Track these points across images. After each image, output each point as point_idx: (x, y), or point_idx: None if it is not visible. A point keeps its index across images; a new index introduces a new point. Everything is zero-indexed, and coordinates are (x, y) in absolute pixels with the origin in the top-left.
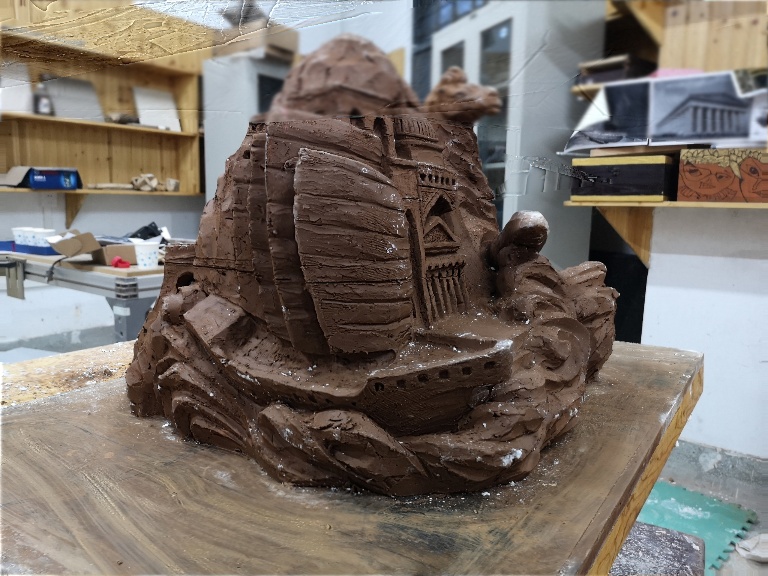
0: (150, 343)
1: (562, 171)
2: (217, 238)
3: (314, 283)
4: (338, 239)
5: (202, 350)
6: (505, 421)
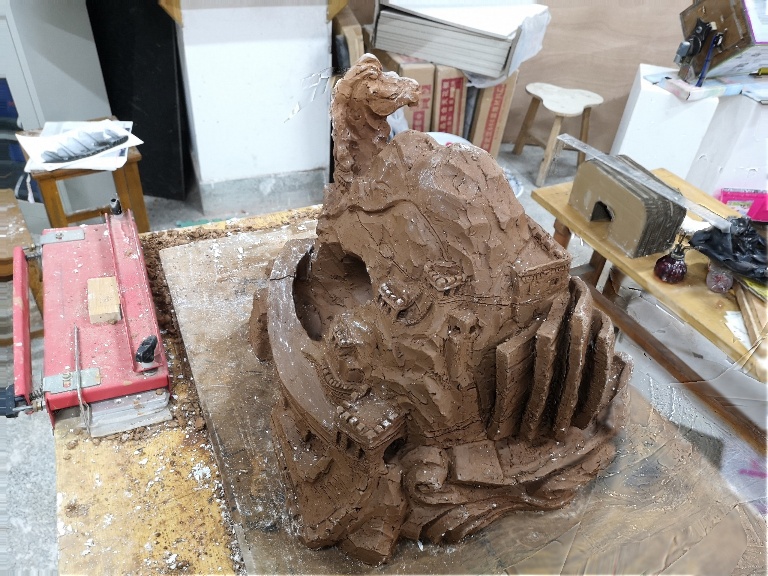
0: (398, 515)
1: (335, 72)
2: (459, 408)
3: None
4: None
5: (466, 486)
6: None
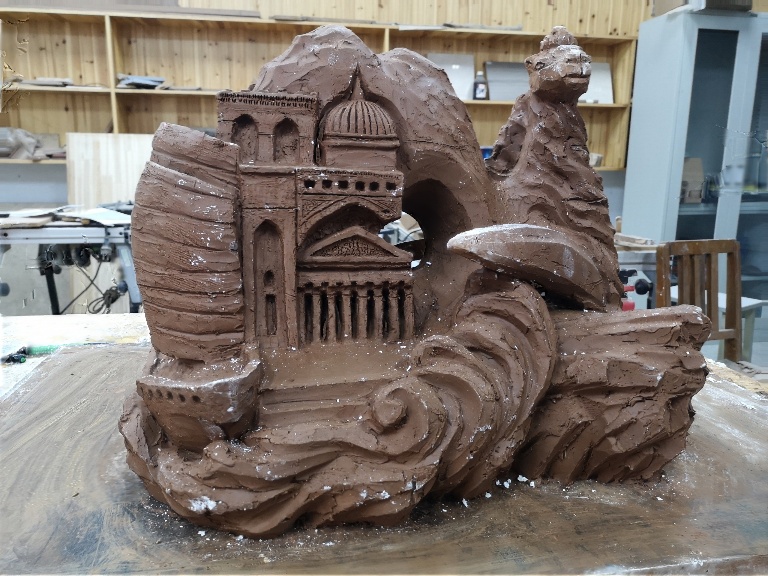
0: None
1: None
2: None
3: (139, 285)
4: (152, 247)
5: None
6: (208, 464)
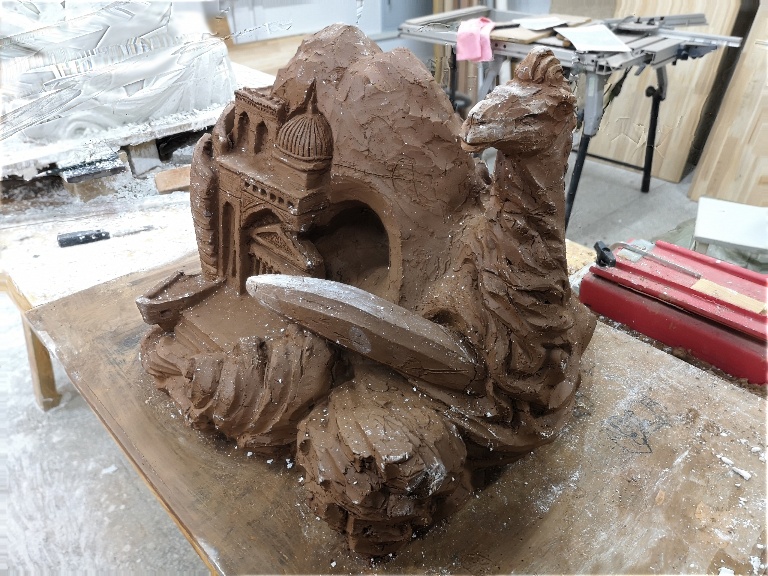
0: None
1: None
2: None
3: None
4: None
5: None
6: None
